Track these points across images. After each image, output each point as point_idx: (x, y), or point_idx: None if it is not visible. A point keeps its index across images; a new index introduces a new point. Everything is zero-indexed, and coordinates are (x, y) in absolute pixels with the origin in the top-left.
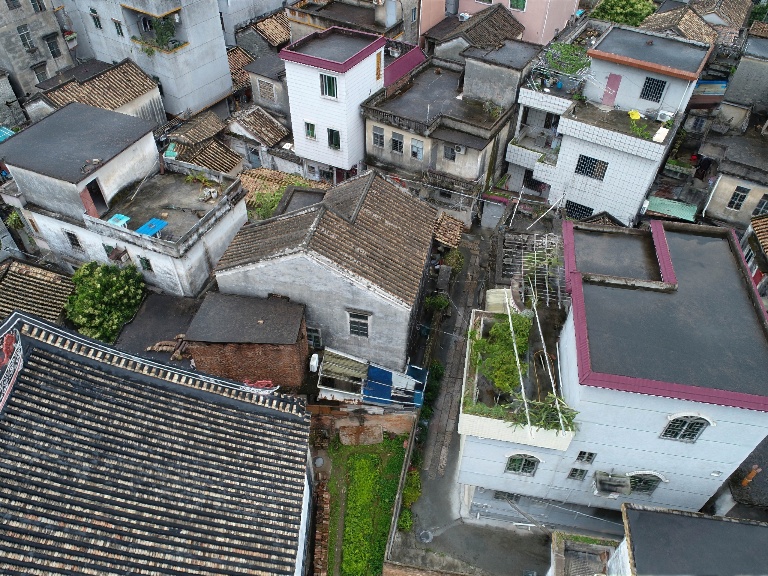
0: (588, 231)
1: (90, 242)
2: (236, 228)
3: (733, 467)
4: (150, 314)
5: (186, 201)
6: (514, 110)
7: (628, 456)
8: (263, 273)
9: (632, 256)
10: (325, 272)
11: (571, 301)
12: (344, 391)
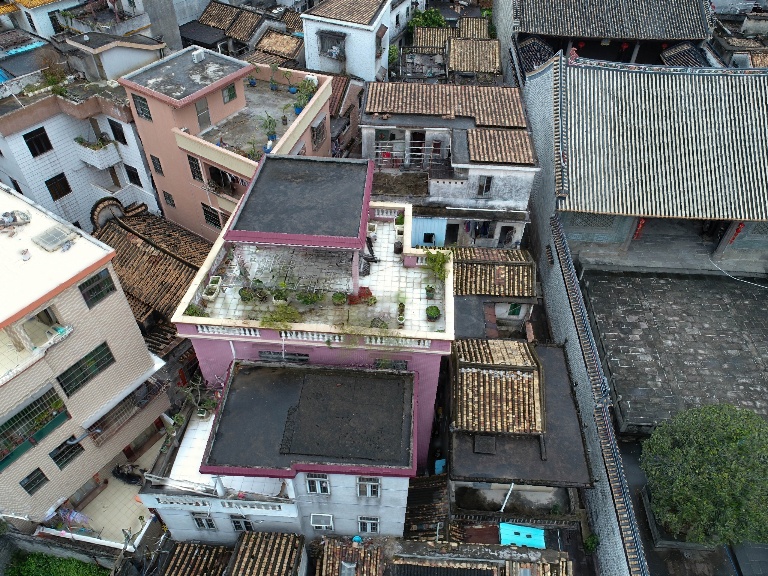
0: None
1: None
2: None
3: None
4: None
5: None
6: None
7: None
8: None
9: None
10: None
11: None
12: None
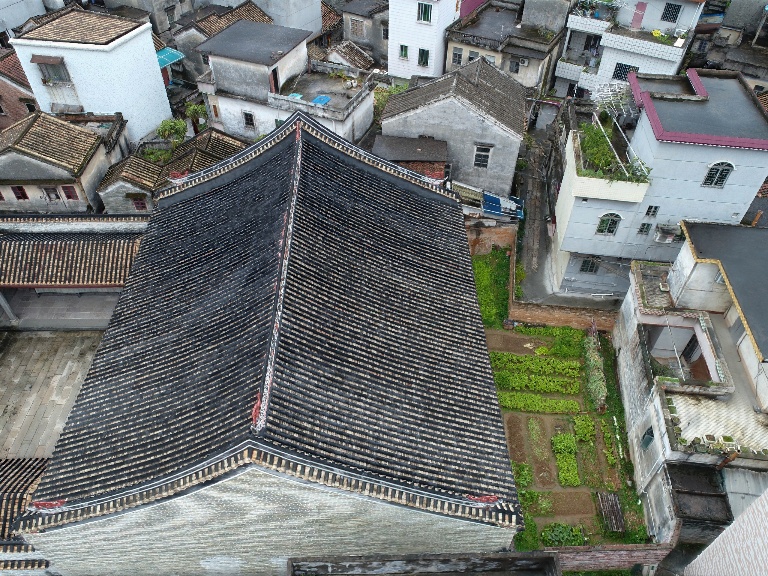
0: (645, 79)
1: (264, 119)
2: (367, 112)
3: (746, 207)
4: None
5: (334, 89)
6: (562, 34)
7: (680, 206)
8: (419, 118)
9: (676, 90)
10: (466, 112)
11: (640, 114)
12: (471, 206)
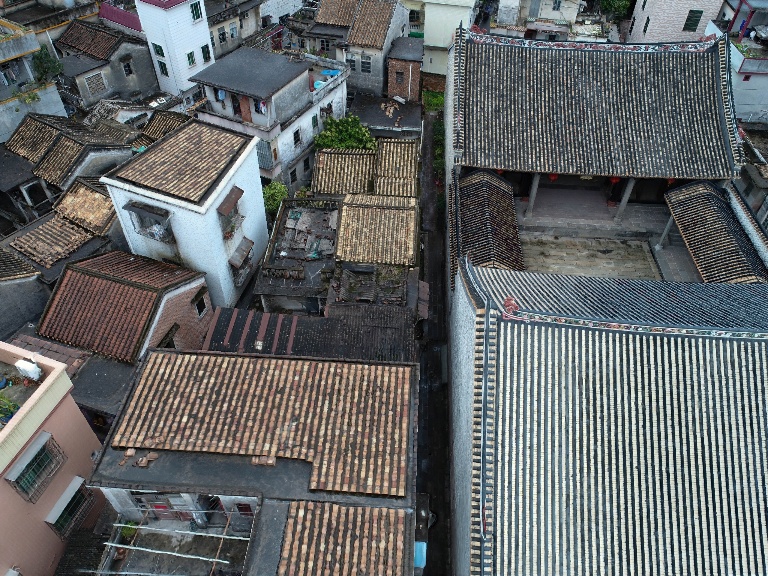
0: None
1: (306, 125)
2: None
3: None
4: (362, 119)
5: None
6: None
7: None
8: None
9: None
10: None
11: None
12: None
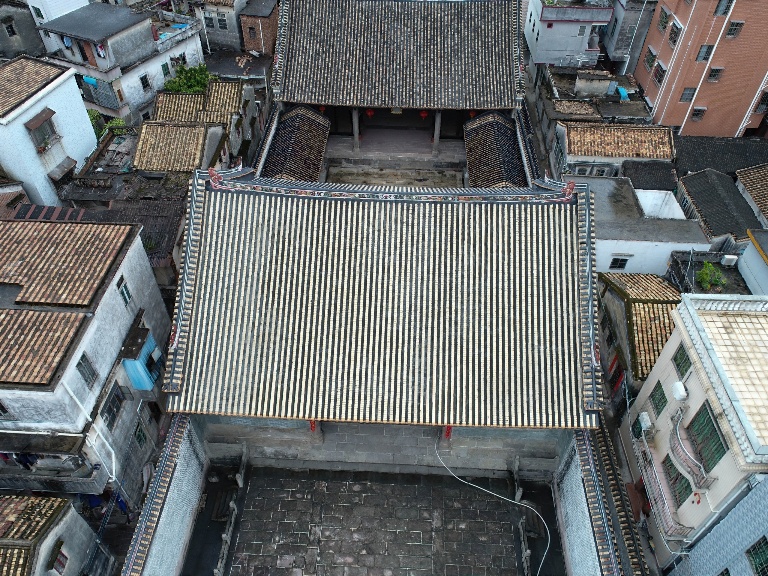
0: None
1: (155, 72)
2: None
3: None
4: (215, 70)
5: None
6: None
7: None
8: None
9: None
10: None
11: None
12: None
